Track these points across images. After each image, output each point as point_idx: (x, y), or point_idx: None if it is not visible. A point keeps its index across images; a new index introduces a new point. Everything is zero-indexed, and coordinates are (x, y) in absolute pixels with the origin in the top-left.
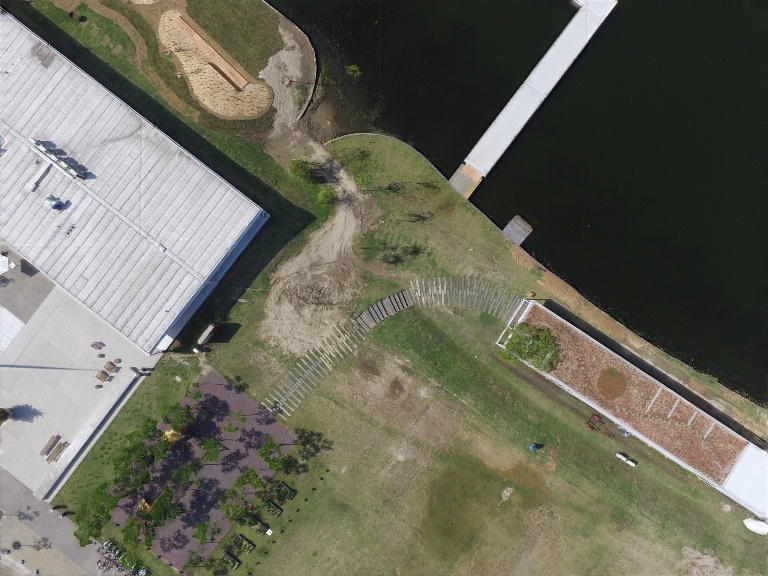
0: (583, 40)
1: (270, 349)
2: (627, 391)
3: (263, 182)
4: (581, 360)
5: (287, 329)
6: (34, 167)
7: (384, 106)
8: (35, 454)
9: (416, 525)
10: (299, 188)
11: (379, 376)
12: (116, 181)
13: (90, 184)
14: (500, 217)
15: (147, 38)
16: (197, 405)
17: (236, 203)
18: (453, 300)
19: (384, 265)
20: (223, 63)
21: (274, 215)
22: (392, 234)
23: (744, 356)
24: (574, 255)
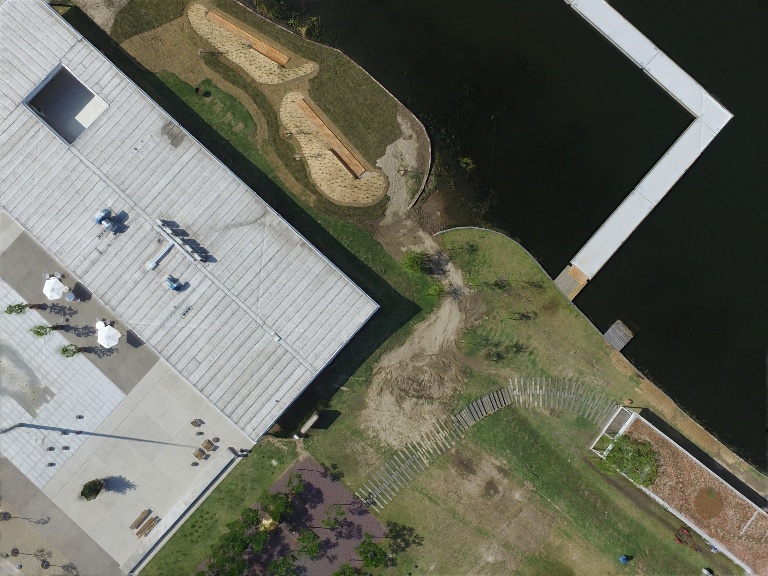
0: (696, 151)
1: (368, 439)
2: (723, 512)
3: (373, 271)
4: (680, 477)
5: (387, 421)
6: (155, 245)
7: (494, 201)
8: (125, 526)
9: None
10: (406, 278)
11: (475, 475)
12: (236, 266)
13: (210, 267)
14: (601, 320)
15: (268, 118)
16: (291, 490)
17: (354, 298)
18: (550, 401)
19: (486, 362)
20: (342, 149)
21: (383, 306)
22: (495, 331)
23: None
24: (672, 364)
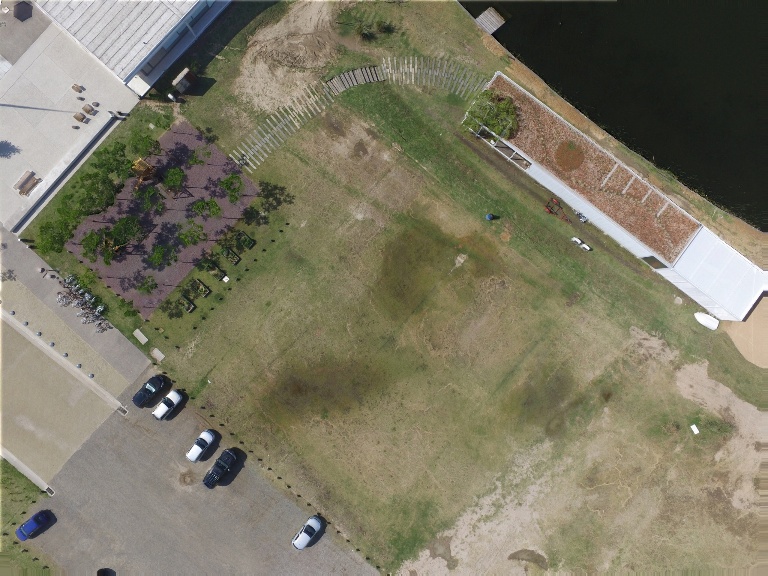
0: None
1: (242, 104)
2: (584, 164)
3: None
4: (541, 131)
5: (260, 87)
6: None
7: None
8: (9, 188)
9: (369, 283)
10: None
11: (344, 137)
12: None
13: None
14: (474, 9)
15: None
16: (167, 151)
17: None
18: (423, 79)
19: (358, 38)
20: None
21: None
22: (369, 13)
23: (705, 158)
24: (544, 50)
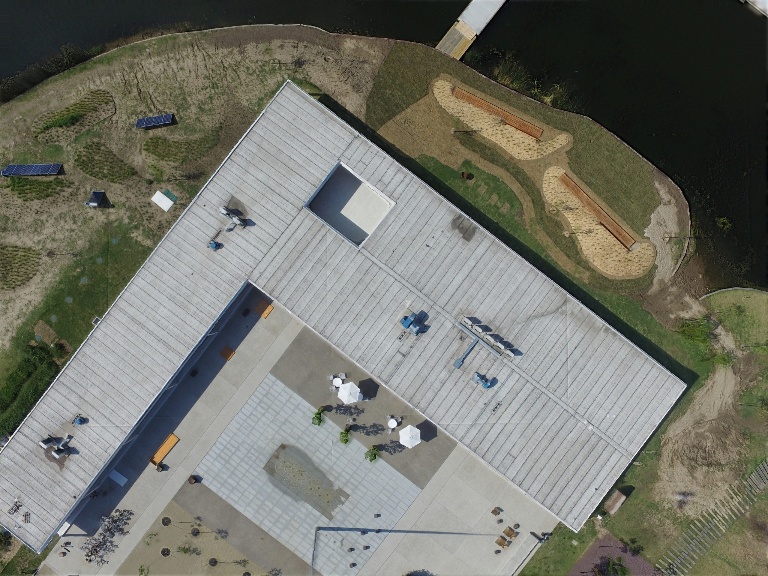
0: None
1: (664, 511)
2: None
3: (654, 343)
4: None
5: (681, 491)
6: (458, 343)
7: (754, 259)
8: None
9: None
10: (680, 345)
11: None
12: (542, 358)
13: (516, 361)
14: None
15: (533, 195)
16: (594, 568)
17: (662, 379)
18: None
19: (766, 423)
20: (610, 221)
21: None
22: None
23: None
24: None
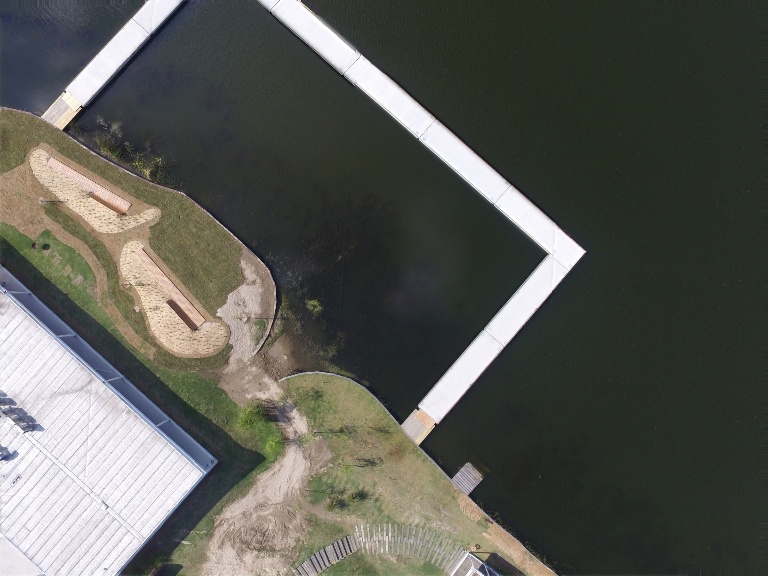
0: (547, 289)
1: None
2: None
3: (214, 424)
4: None
5: (228, 574)
6: None
7: (342, 344)
8: None
9: None
10: None
11: None
12: (63, 435)
13: (38, 436)
14: (451, 463)
15: (108, 269)
16: None
17: (180, 465)
18: (397, 548)
19: None
20: (182, 299)
21: (222, 461)
22: (340, 478)
23: None
24: (523, 505)
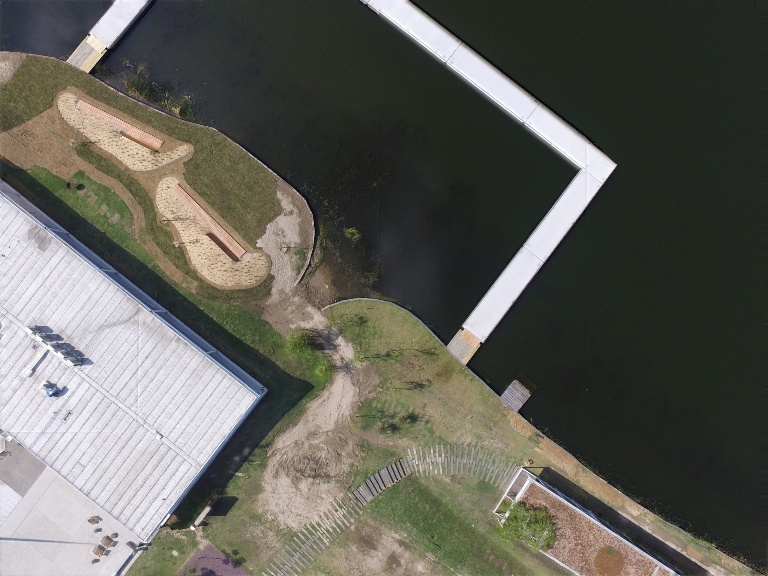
0: (582, 203)
1: (267, 523)
2: (624, 570)
3: (261, 354)
4: (578, 539)
5: (284, 503)
6: (31, 352)
7: (382, 269)
8: None
9: None
10: (297, 356)
11: (376, 551)
12: (113, 367)
13: (87, 370)
14: (498, 381)
15: (145, 206)
16: None
17: (233, 390)
18: (451, 468)
19: (382, 435)
20: (221, 232)
21: (271, 389)
22: (390, 402)
23: (742, 521)
24: (572, 419)
